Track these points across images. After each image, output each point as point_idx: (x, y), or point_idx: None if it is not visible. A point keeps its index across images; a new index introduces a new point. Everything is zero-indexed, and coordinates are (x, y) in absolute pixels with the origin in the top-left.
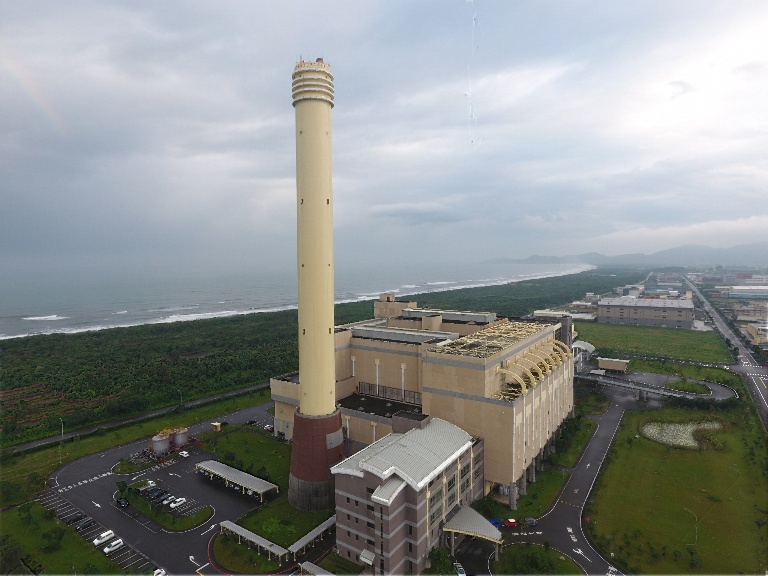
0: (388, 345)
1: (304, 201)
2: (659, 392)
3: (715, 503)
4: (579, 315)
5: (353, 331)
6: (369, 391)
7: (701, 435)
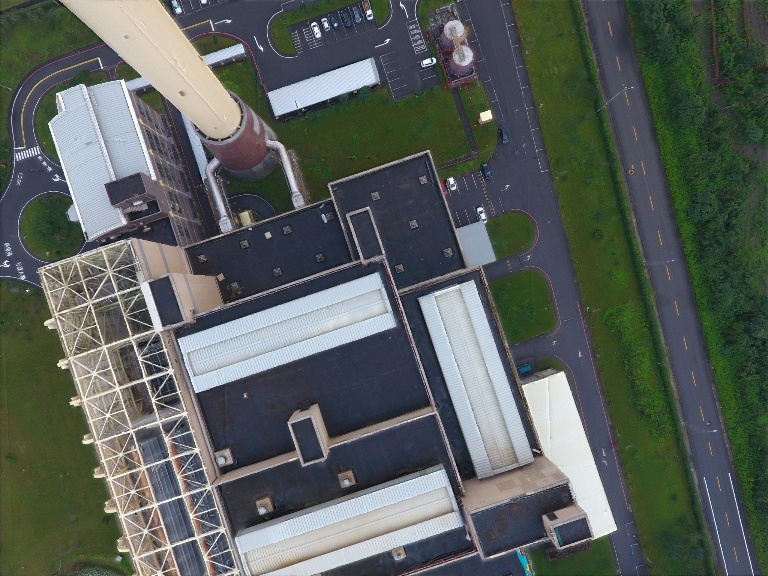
0: None
1: None
2: None
3: (8, 451)
4: None
5: None
6: None
7: None
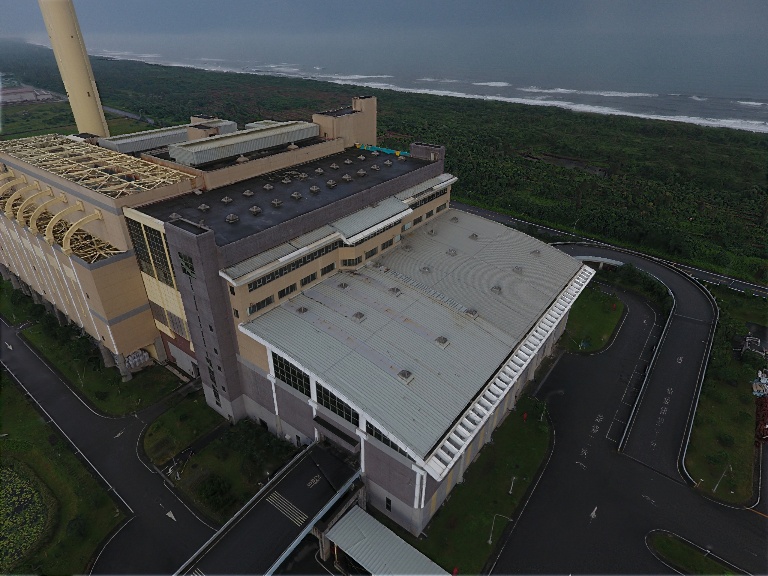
0: None
1: None
2: None
3: None
4: None
5: None
6: None
7: None
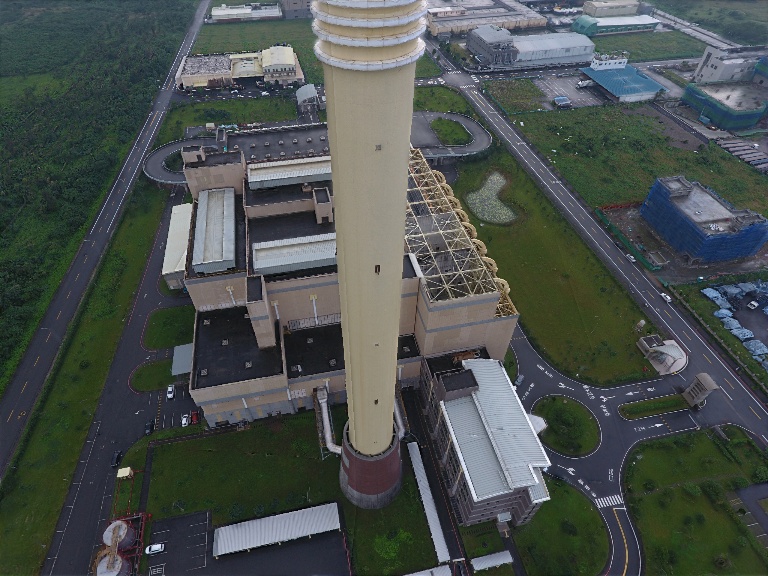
0: (328, 278)
1: (382, 268)
2: (453, 155)
3: (569, 279)
4: (265, 12)
5: (258, 271)
6: (304, 325)
7: (506, 199)
